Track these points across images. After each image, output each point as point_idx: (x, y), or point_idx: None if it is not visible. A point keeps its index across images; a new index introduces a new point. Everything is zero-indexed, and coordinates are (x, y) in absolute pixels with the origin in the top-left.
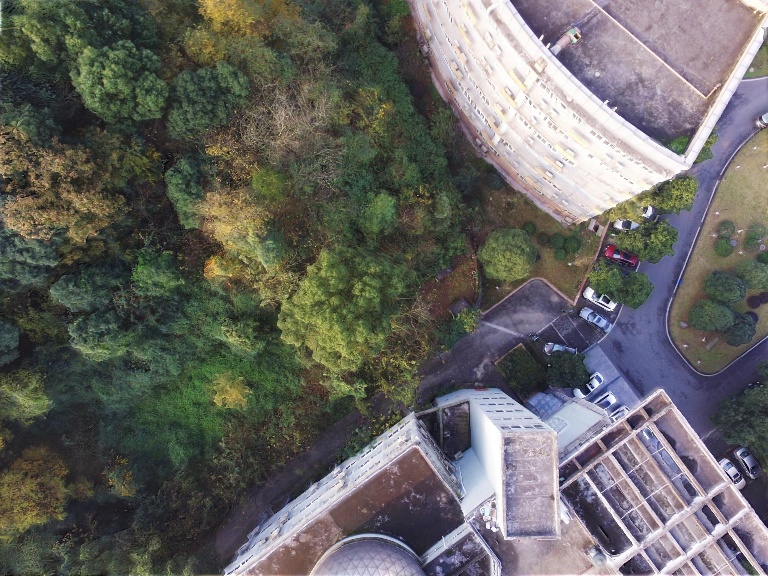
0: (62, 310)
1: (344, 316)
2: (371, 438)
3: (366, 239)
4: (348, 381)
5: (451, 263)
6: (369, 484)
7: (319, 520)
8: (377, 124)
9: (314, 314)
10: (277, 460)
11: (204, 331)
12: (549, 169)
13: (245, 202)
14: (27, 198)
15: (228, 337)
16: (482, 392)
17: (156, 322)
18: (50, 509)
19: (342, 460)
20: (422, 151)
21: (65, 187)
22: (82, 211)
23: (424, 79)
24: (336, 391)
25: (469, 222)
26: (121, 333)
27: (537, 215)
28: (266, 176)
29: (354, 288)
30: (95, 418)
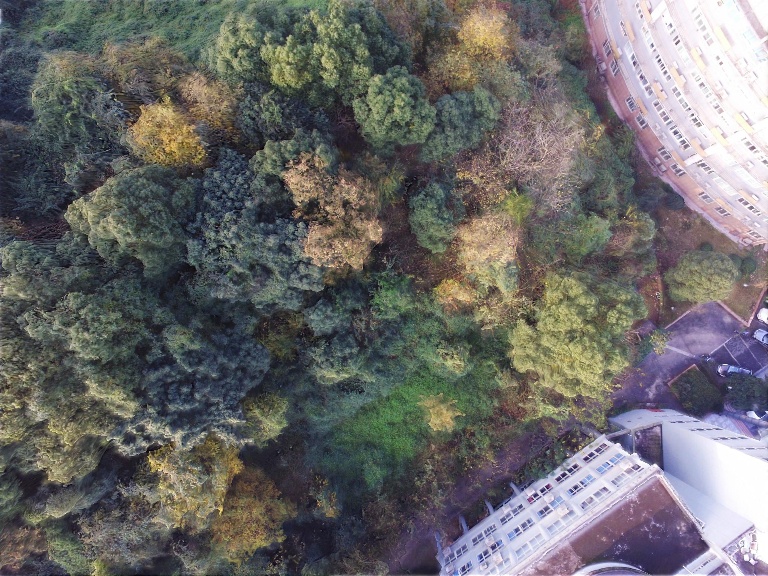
0: (295, 332)
1: (602, 345)
2: (563, 460)
3: (569, 261)
4: (553, 404)
5: (637, 284)
6: (608, 512)
7: (557, 548)
8: (594, 146)
9: (565, 341)
10: (473, 482)
11: (416, 353)
12: (756, 193)
13: (506, 228)
14: (324, 226)
15: (445, 360)
16: (663, 414)
17: (380, 345)
18: (272, 532)
19: (521, 480)
20: (612, 171)
21: (351, 214)
22: (369, 239)
23: (601, 96)
24: (538, 414)
25: (657, 243)
26: (359, 357)
27: (713, 235)
28: (523, 202)
29: (608, 316)
30: (293, 438)
